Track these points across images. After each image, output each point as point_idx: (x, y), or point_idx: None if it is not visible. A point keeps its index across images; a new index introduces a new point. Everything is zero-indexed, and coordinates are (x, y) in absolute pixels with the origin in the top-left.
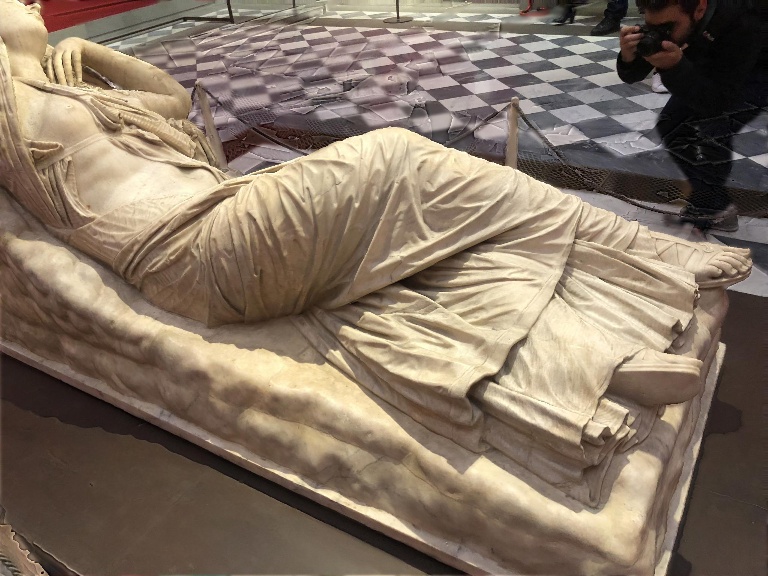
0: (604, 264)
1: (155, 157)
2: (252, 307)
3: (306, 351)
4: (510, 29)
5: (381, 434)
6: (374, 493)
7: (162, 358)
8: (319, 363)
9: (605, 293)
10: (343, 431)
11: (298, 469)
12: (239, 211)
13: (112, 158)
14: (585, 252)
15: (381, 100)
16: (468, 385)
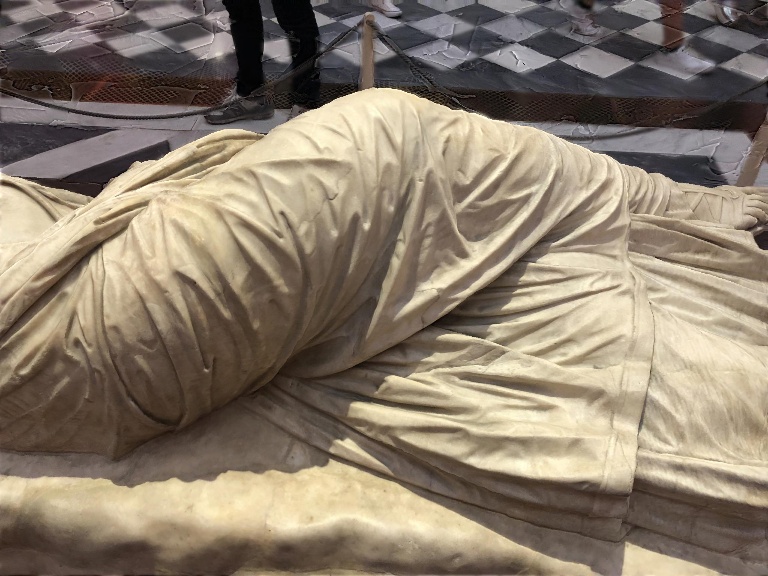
0: (662, 239)
1: None
2: (193, 412)
3: (293, 450)
4: None
5: (475, 554)
6: None
7: (46, 538)
8: (320, 463)
9: (674, 277)
10: (412, 565)
11: None
12: (157, 271)
13: None
14: (641, 229)
15: (164, 24)
16: (633, 473)
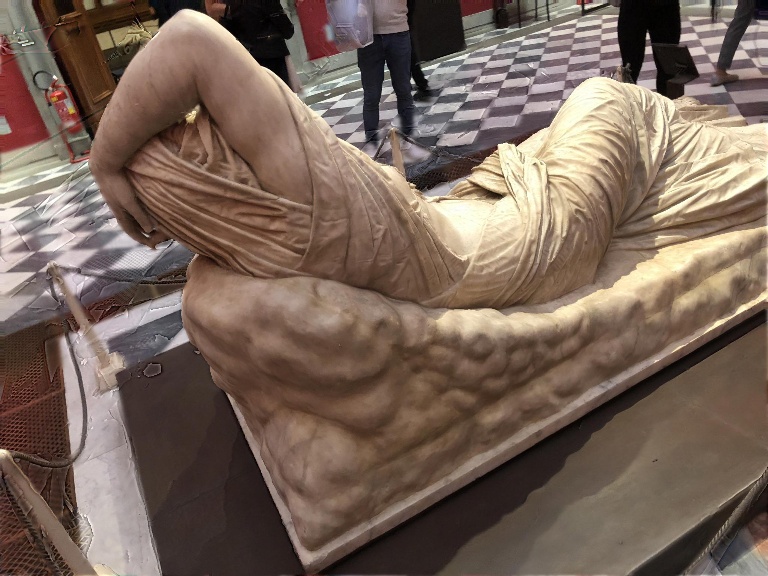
0: (686, 116)
1: (427, 200)
2: None
3: (642, 254)
4: (305, 99)
5: (746, 240)
6: (759, 282)
7: (603, 322)
8: (656, 253)
9: None
10: (729, 258)
11: (715, 316)
12: (593, 162)
13: (429, 205)
14: None
15: None
16: None
